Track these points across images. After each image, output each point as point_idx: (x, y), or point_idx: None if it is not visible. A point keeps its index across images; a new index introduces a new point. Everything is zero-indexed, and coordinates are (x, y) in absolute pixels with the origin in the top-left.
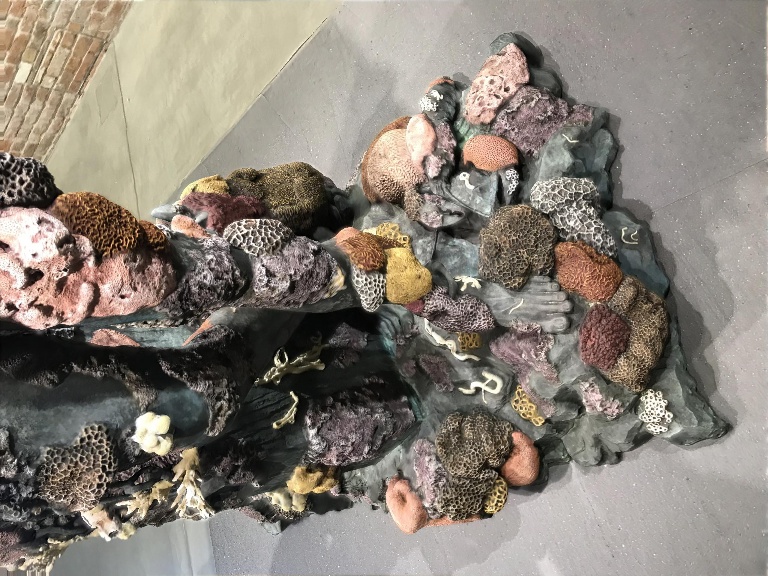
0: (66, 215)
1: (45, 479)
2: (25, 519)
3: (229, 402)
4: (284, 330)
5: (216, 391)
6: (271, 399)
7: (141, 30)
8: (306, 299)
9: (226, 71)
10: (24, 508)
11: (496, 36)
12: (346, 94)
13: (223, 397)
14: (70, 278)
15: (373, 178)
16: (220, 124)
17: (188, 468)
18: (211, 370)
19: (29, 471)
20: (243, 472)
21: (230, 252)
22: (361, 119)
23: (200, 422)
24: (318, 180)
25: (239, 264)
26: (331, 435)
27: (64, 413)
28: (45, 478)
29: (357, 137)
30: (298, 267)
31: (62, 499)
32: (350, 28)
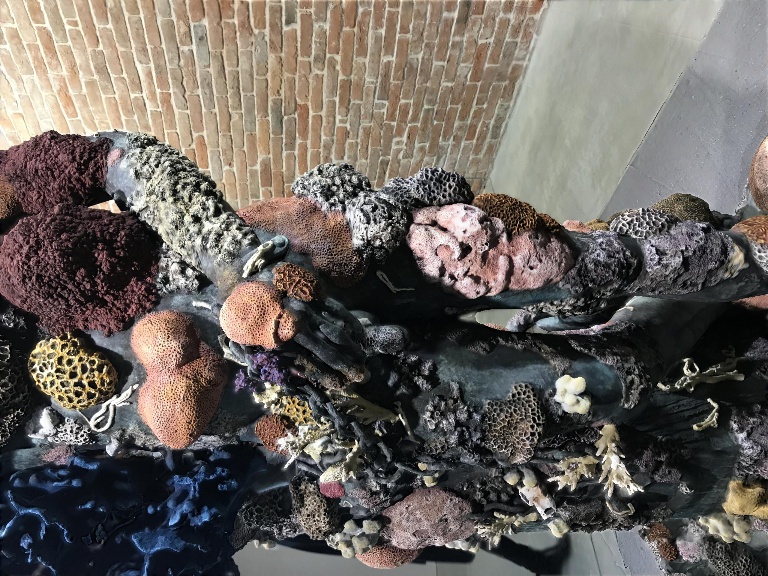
0: (482, 207)
1: (489, 427)
2: (477, 461)
3: (640, 378)
4: (688, 330)
5: (625, 366)
6: (687, 405)
7: (511, 160)
8: (704, 279)
9: (592, 164)
10: (475, 452)
11: None
12: (718, 131)
13: (633, 372)
14: (490, 253)
15: (763, 182)
16: (593, 213)
17: (609, 442)
18: (617, 349)
19: (476, 416)
20: (668, 469)
21: (618, 238)
22: (740, 148)
23: (614, 392)
24: (701, 203)
25: (628, 247)
26: (765, 440)
27: (497, 374)
28: (489, 426)
29: (739, 167)
30: (689, 243)
31: (503, 449)
32: (710, 69)
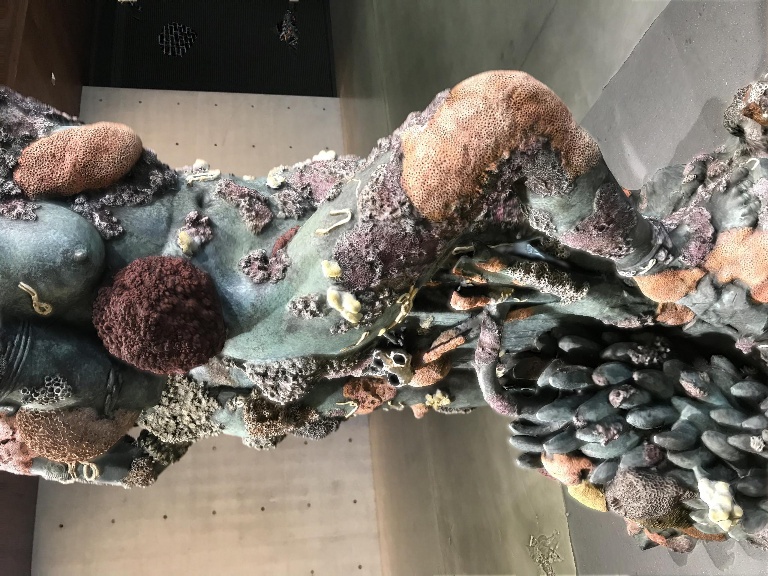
0: None
1: None
2: None
3: None
4: None
5: None
6: None
7: None
8: None
9: None
10: None
11: (691, 575)
12: None
13: None
14: None
15: None
16: None
17: None
18: None
19: None
20: None
21: None
22: None
23: None
24: None
25: None
26: None
27: None
28: None
29: None
30: None
31: None
32: None
